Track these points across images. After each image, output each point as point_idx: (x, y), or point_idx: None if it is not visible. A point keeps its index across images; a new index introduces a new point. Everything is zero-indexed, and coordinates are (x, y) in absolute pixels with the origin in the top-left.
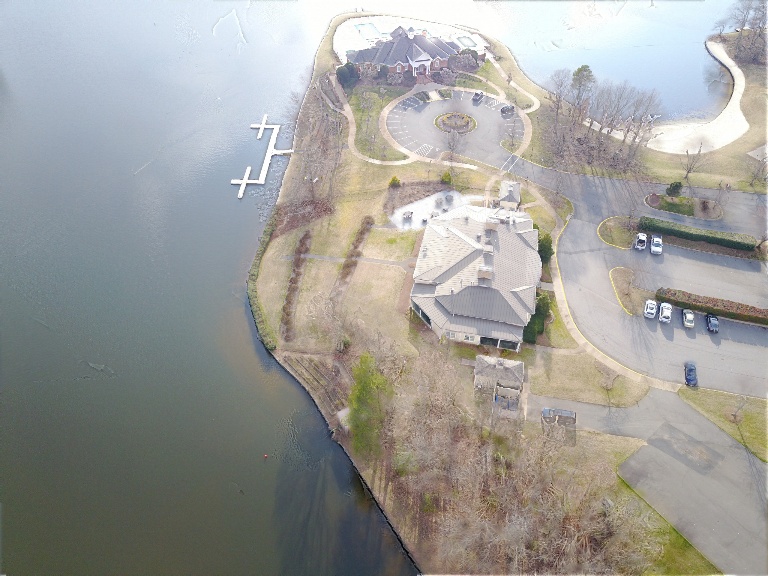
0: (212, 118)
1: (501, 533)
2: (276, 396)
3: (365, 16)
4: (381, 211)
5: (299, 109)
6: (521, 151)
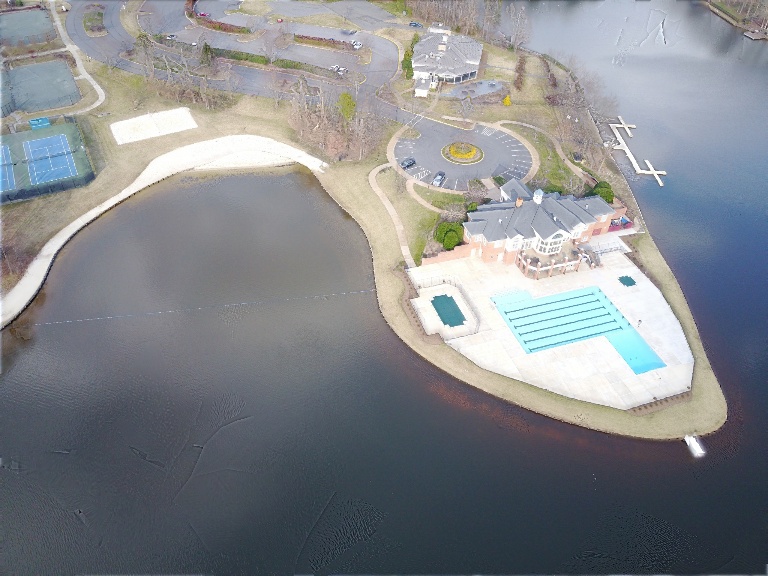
0: (725, 205)
1: None
2: (534, 47)
3: (663, 402)
4: (511, 89)
5: (634, 194)
6: (403, 129)
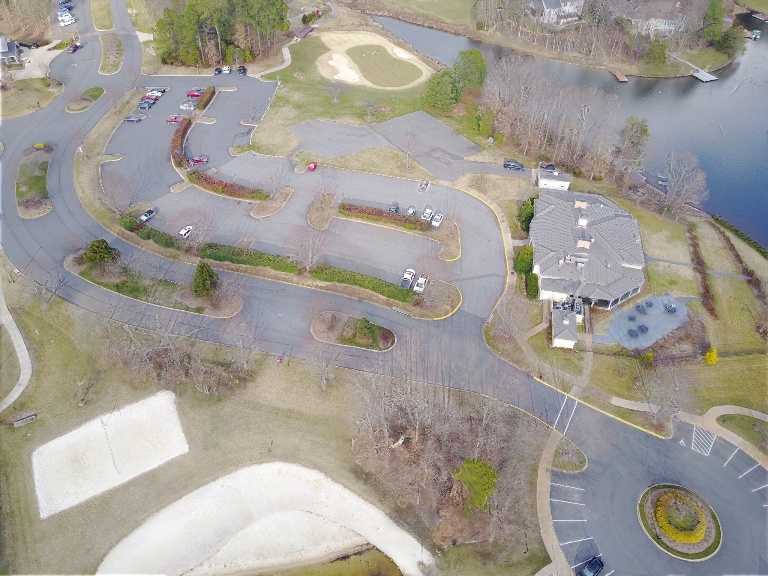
0: None
1: (551, 105)
2: None
3: None
4: (703, 318)
5: None
6: (552, 441)
